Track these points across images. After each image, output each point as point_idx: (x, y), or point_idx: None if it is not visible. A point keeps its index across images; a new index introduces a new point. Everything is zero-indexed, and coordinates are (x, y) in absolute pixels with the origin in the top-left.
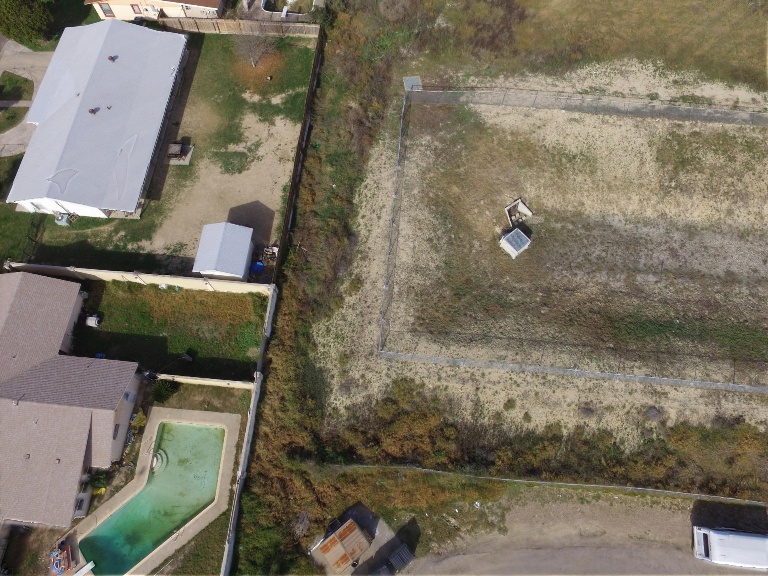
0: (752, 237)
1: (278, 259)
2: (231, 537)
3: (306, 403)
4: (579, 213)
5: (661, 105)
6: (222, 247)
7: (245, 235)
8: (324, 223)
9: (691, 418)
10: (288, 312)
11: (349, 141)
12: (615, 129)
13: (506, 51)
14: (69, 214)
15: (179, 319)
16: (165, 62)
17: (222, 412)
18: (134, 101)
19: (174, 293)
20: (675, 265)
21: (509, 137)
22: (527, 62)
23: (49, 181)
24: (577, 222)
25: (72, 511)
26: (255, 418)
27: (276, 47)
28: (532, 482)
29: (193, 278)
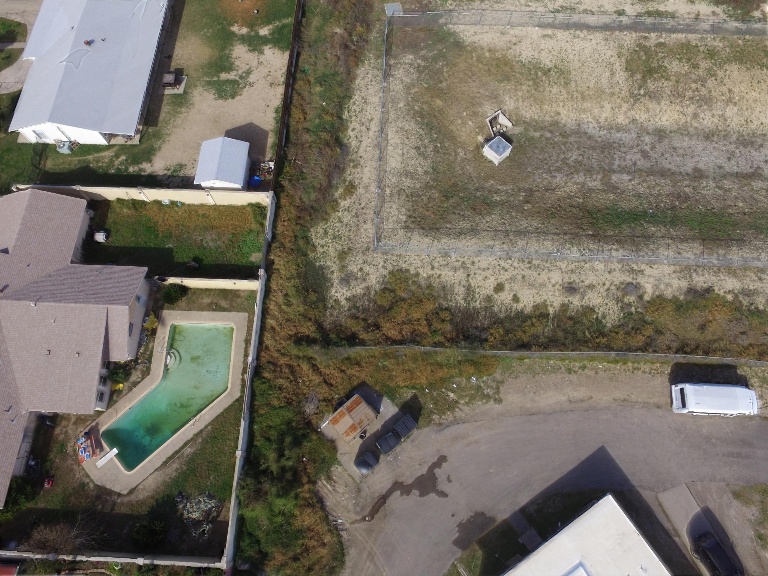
0: (717, 137)
1: (275, 171)
2: (246, 416)
3: (309, 297)
4: (556, 122)
5: (628, 20)
6: (221, 159)
7: (242, 148)
8: (317, 137)
9: (666, 291)
10: (287, 219)
11: (336, 63)
12: (586, 43)
13: None
14: (70, 142)
15: (183, 231)
16: None
17: (230, 312)
18: None
19: (177, 208)
20: (647, 165)
21: (487, 54)
22: None
23: (50, 107)
24: (554, 131)
25: (94, 399)
26: (261, 313)
27: None
28: (523, 354)
29: (195, 190)
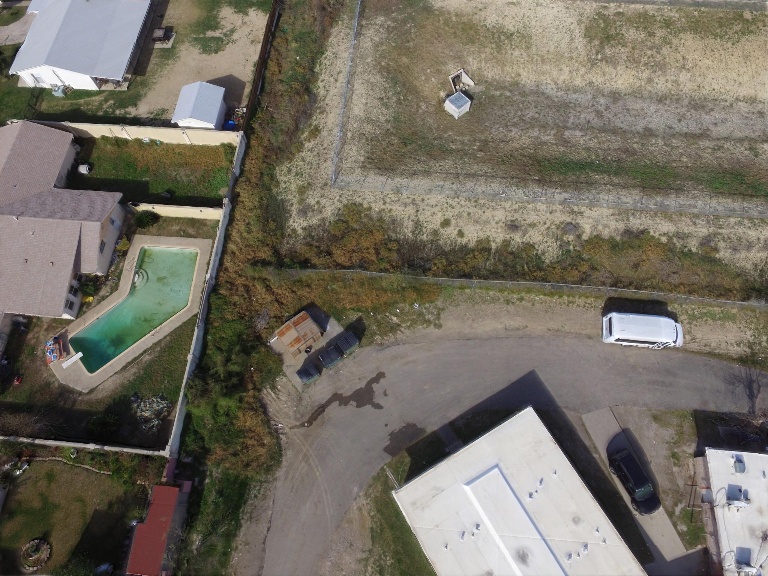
0: (669, 101)
1: (247, 114)
2: (200, 326)
3: (268, 225)
4: (516, 83)
5: None
6: (197, 100)
7: (218, 92)
8: (288, 87)
9: (603, 232)
10: (255, 158)
11: (312, 23)
12: (548, 10)
13: None
14: (65, 86)
15: (160, 167)
16: None
17: (196, 238)
18: None
19: (156, 147)
20: (600, 123)
21: (454, 18)
22: None
23: (47, 51)
24: (514, 90)
25: (63, 304)
26: (224, 239)
27: None
28: (463, 283)
29: (172, 128)
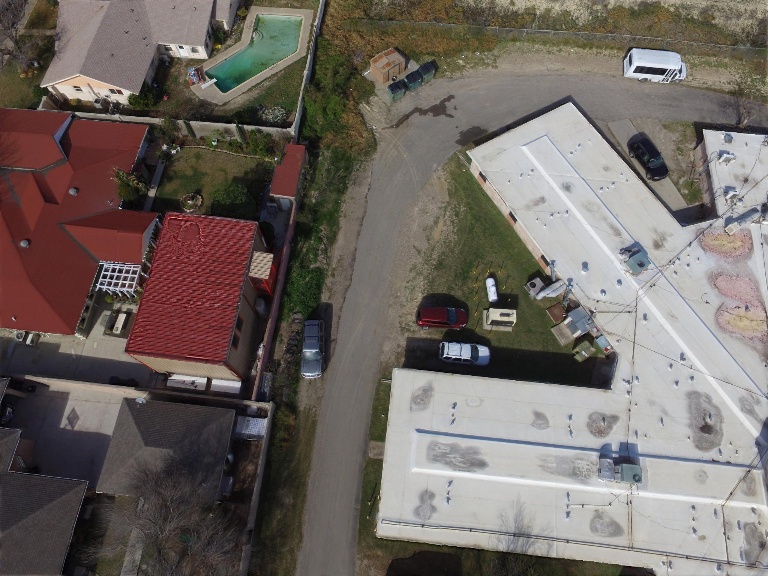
0: None
1: None
2: (311, 56)
3: None
4: None
5: None
6: None
7: None
8: None
9: (624, 3)
10: None
11: None
12: None
13: None
14: None
15: None
16: None
17: (300, 8)
18: None
19: None
20: None
21: None
22: None
23: None
24: None
25: (205, 36)
26: (324, 6)
27: None
28: (515, 34)
29: None
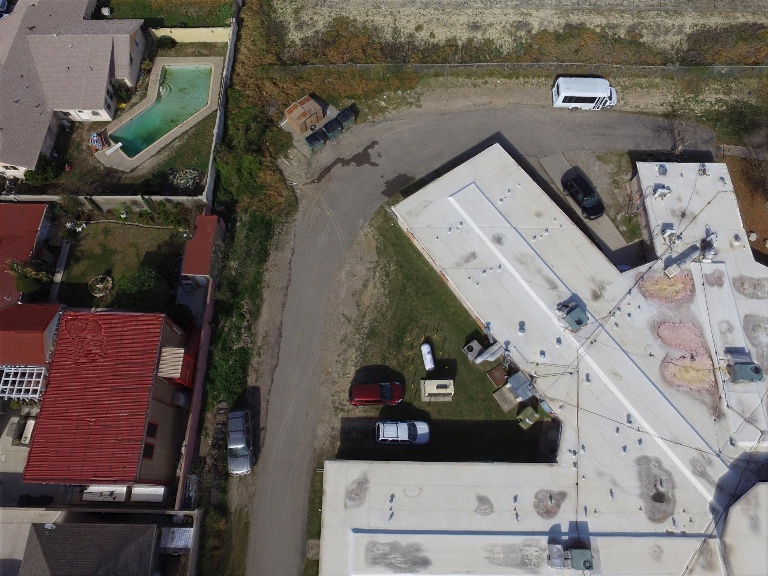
0: None
1: None
2: (221, 111)
3: (271, 39)
4: None
5: None
6: None
7: None
8: None
9: (549, 27)
10: None
11: None
12: None
13: None
14: None
15: (172, 7)
16: None
17: (209, 56)
18: None
19: None
20: None
21: None
22: None
23: None
24: None
25: (104, 99)
26: (234, 52)
27: None
28: (437, 70)
29: None
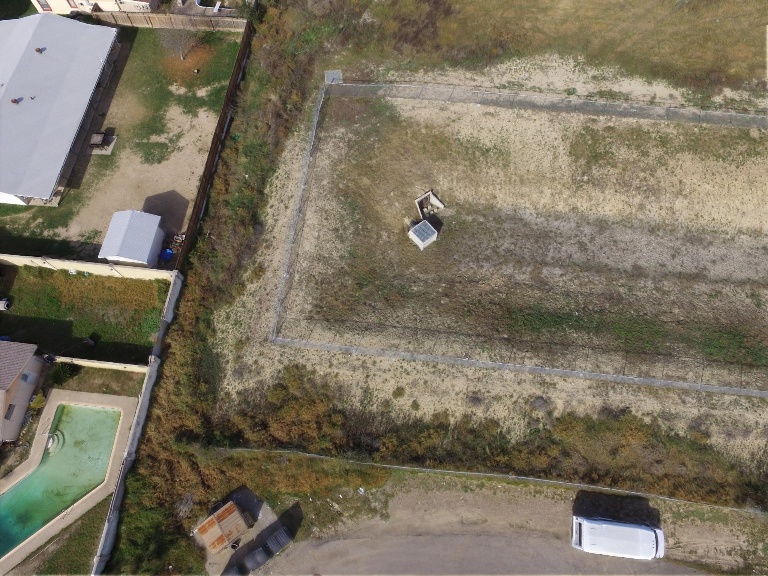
0: (663, 232)
1: (185, 247)
2: (113, 516)
3: (199, 387)
4: (491, 206)
5: (577, 100)
6: (127, 234)
7: (152, 222)
8: (233, 212)
9: (578, 409)
10: (191, 299)
11: (266, 133)
12: (529, 123)
13: (428, 46)
14: None
15: (86, 304)
16: (95, 55)
17: (120, 395)
18: (59, 92)
19: (84, 279)
20: (583, 258)
21: (423, 130)
22: (448, 57)
23: None
24: (488, 215)
25: None
26: (149, 401)
27: (206, 41)
28: (414, 469)
29: (99, 264)
